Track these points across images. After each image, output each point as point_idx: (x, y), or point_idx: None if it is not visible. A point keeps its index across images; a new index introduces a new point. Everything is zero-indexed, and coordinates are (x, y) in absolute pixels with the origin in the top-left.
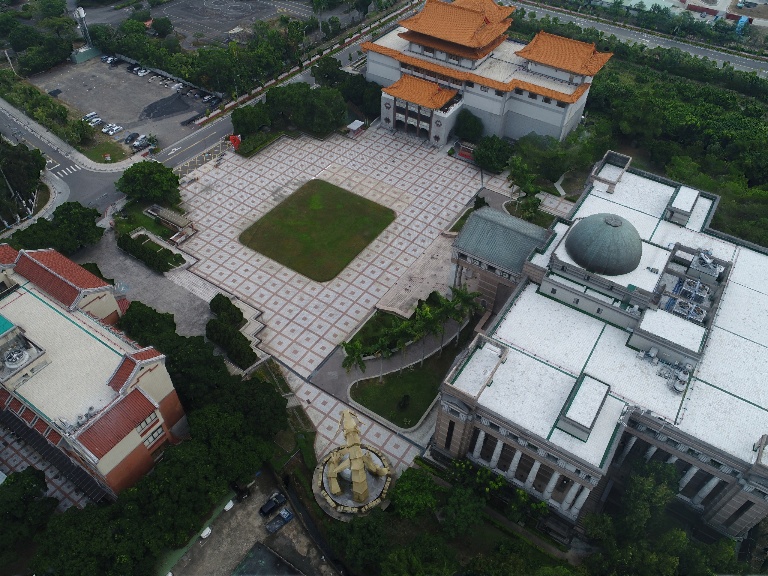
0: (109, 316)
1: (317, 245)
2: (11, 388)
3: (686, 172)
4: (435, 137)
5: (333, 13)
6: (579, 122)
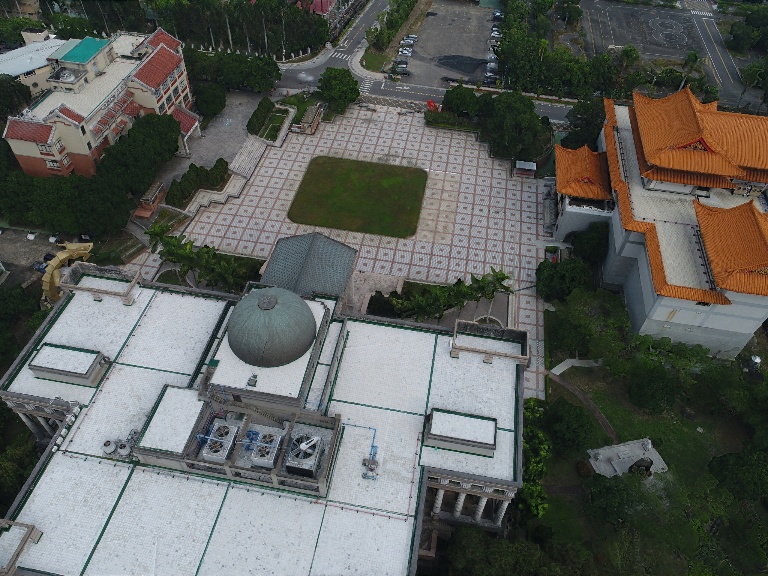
0: (150, 109)
1: (333, 200)
2: (52, 88)
3: (679, 496)
4: None
5: (749, 91)
6: (731, 355)
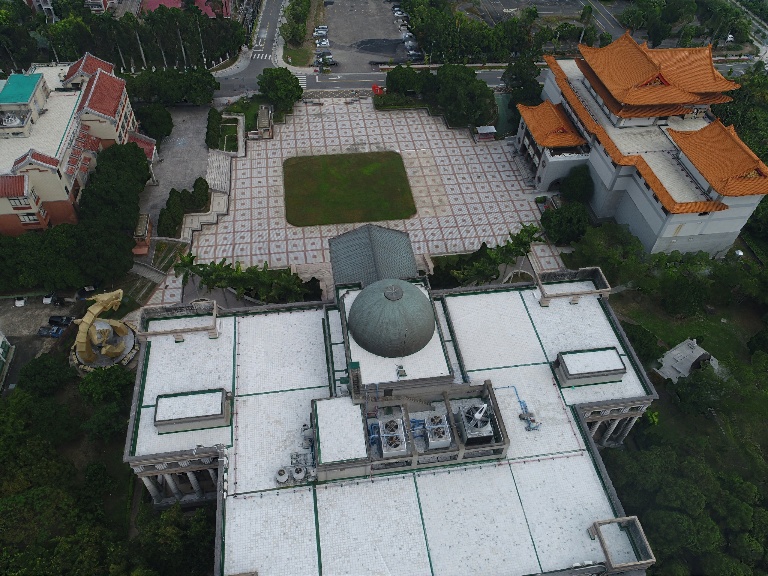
0: (108, 140)
1: (324, 197)
2: None
3: (747, 375)
4: (539, 177)
5: (630, 33)
6: (722, 254)
